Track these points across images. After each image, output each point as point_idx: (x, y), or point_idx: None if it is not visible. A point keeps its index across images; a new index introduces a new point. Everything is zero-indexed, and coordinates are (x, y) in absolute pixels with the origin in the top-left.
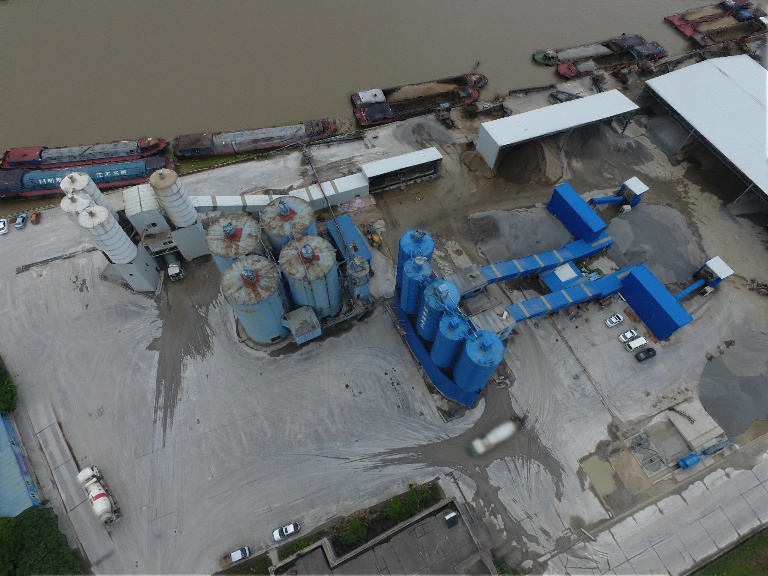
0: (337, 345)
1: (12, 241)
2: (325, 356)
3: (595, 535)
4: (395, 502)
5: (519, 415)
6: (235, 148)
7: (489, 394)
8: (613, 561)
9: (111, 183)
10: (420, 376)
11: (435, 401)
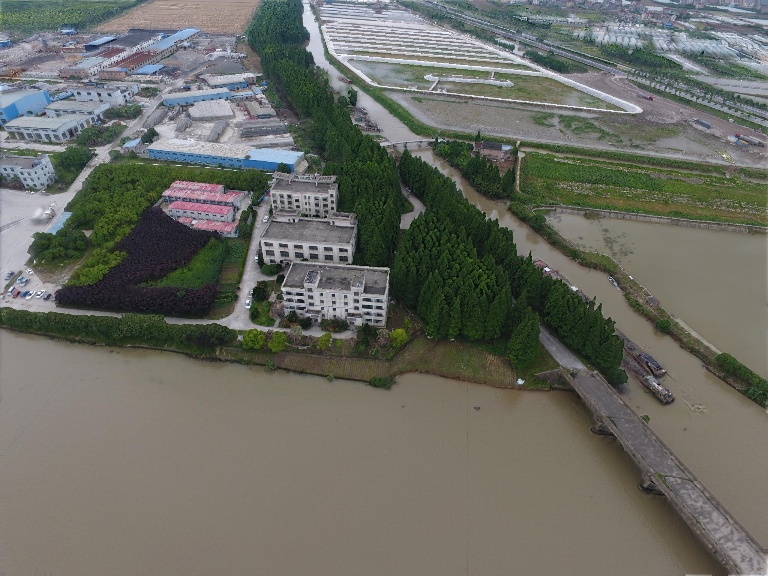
0: None
1: None
2: None
3: None
4: None
5: None
6: None
7: None
8: None
9: None
10: None
11: None
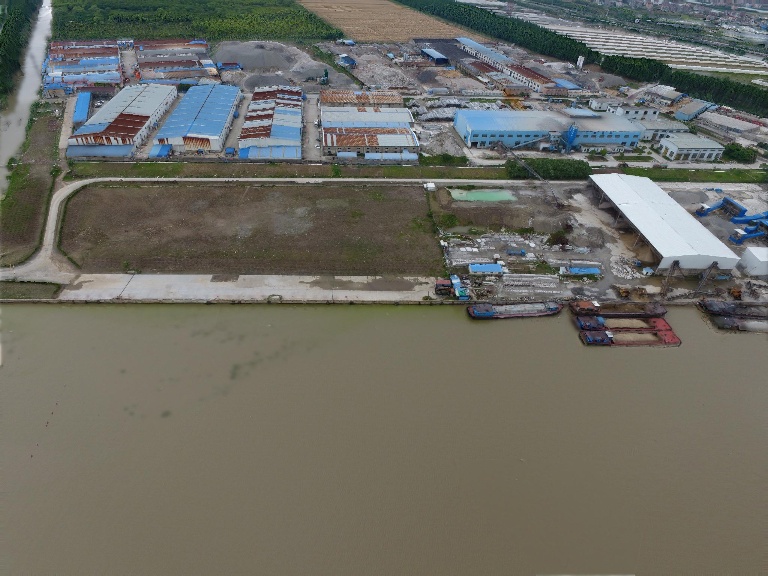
0: None
1: None
2: None
3: (747, 190)
4: None
5: None
6: None
7: None
8: None
9: None
10: None
11: None
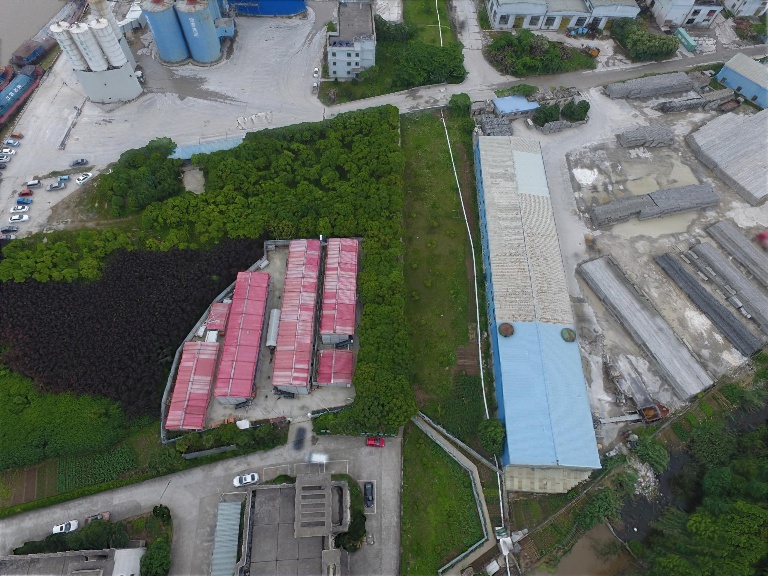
0: (242, 37)
1: (27, 151)
2: (244, 42)
3: (376, 2)
4: (328, 27)
5: (320, 0)
6: (54, 38)
7: (305, 4)
8: (387, 2)
9: (21, 98)
10: (280, 19)
11: (296, 19)
